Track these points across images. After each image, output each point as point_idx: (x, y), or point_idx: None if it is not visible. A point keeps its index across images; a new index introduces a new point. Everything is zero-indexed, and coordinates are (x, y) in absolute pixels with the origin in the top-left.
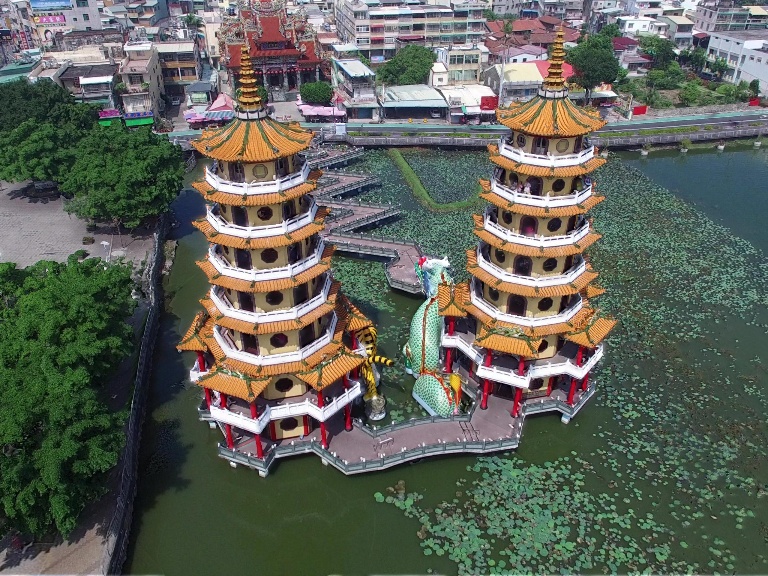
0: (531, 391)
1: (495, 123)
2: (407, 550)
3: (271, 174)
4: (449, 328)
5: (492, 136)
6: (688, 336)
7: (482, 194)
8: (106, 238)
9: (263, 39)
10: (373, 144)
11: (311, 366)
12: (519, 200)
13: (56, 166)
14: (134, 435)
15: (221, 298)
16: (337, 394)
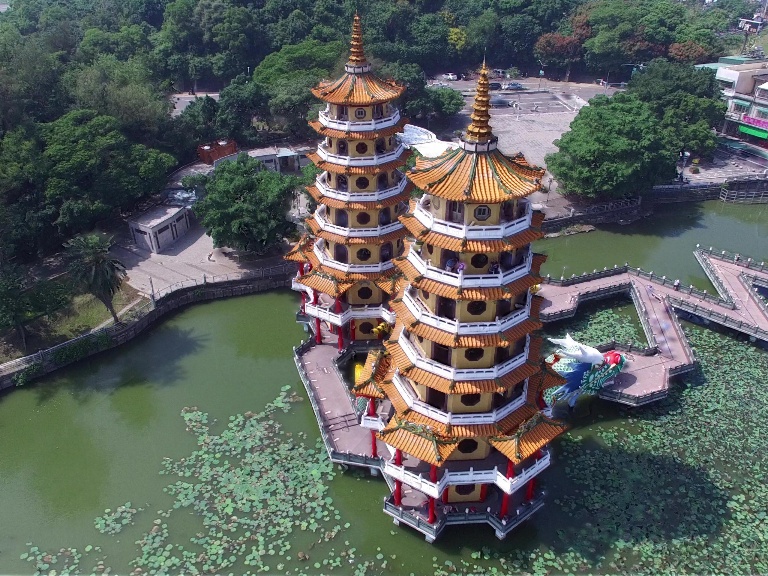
0: None
1: None
2: (236, 407)
3: None
4: None
5: None
6: None
7: None
8: (556, 195)
9: None
10: None
11: None
12: None
13: None
14: None
15: None
16: None
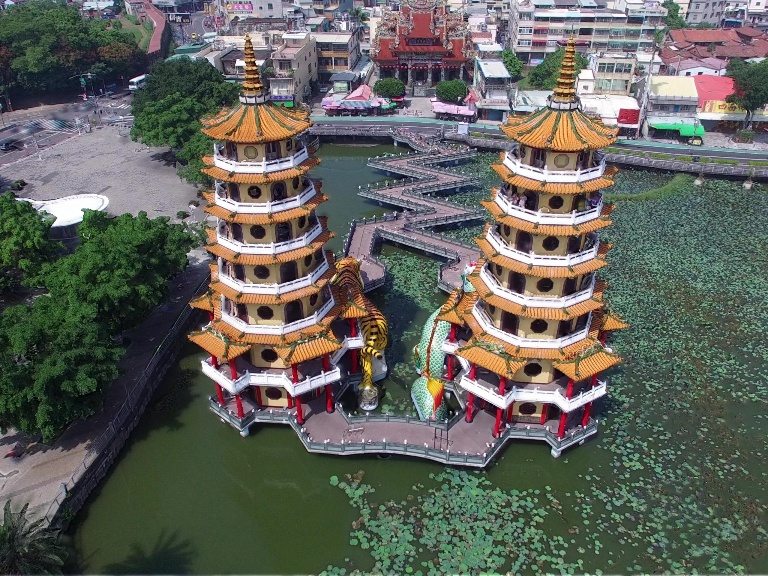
0: (522, 415)
1: (632, 138)
2: (336, 535)
3: (261, 156)
4: (450, 334)
5: (621, 151)
6: (746, 397)
7: (483, 202)
8: None
9: (412, 35)
10: (491, 147)
11: (288, 342)
12: (512, 212)
13: (189, 136)
14: (152, 375)
15: (227, 266)
16: (314, 374)
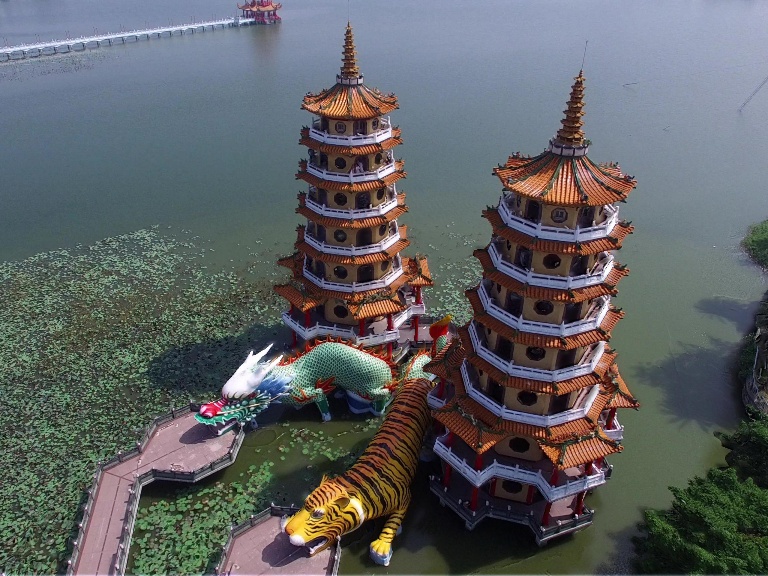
0: None
1: None
2: None
3: None
4: None
5: None
6: (235, 278)
7: (386, 184)
8: None
9: None
10: None
11: None
12: None
13: None
14: None
15: None
16: None
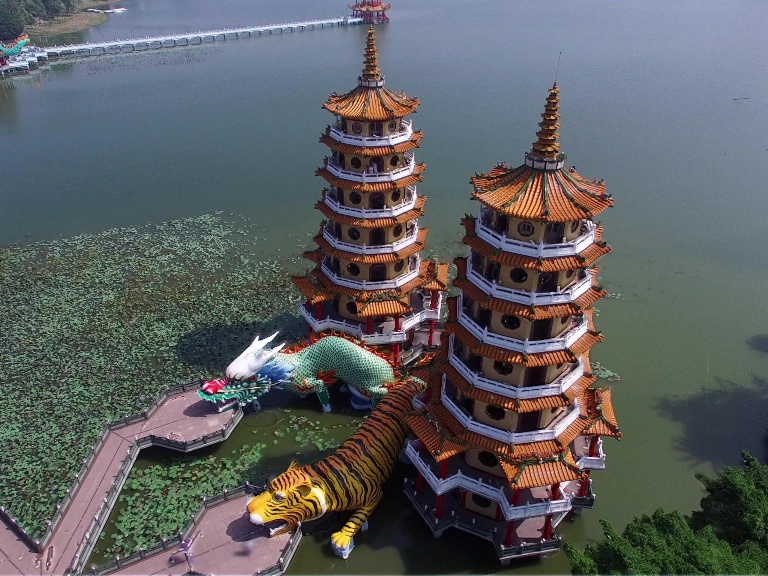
0: None
1: None
2: None
3: None
4: None
5: None
6: (278, 267)
7: None
8: None
9: None
10: None
11: None
12: None
13: None
14: None
15: None
16: None
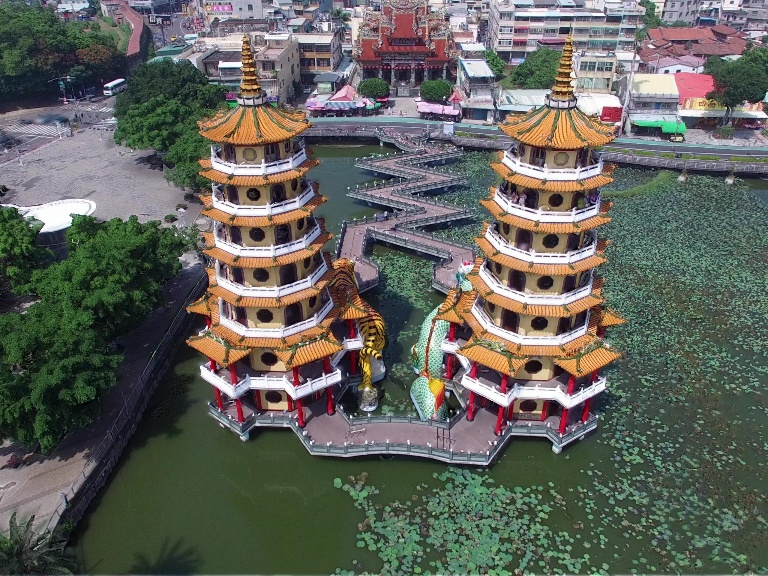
0: (523, 412)
1: None
2: (343, 537)
3: (260, 158)
4: (449, 333)
5: (605, 149)
6: (740, 389)
7: (482, 201)
8: (197, 207)
9: (395, 35)
10: (477, 146)
11: (289, 345)
12: (512, 211)
13: (174, 139)
14: (148, 381)
15: (224, 269)
16: (315, 376)
